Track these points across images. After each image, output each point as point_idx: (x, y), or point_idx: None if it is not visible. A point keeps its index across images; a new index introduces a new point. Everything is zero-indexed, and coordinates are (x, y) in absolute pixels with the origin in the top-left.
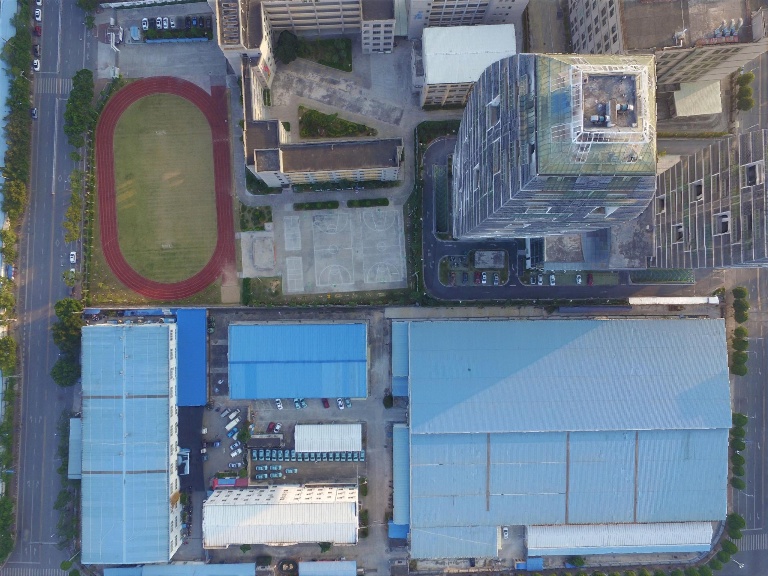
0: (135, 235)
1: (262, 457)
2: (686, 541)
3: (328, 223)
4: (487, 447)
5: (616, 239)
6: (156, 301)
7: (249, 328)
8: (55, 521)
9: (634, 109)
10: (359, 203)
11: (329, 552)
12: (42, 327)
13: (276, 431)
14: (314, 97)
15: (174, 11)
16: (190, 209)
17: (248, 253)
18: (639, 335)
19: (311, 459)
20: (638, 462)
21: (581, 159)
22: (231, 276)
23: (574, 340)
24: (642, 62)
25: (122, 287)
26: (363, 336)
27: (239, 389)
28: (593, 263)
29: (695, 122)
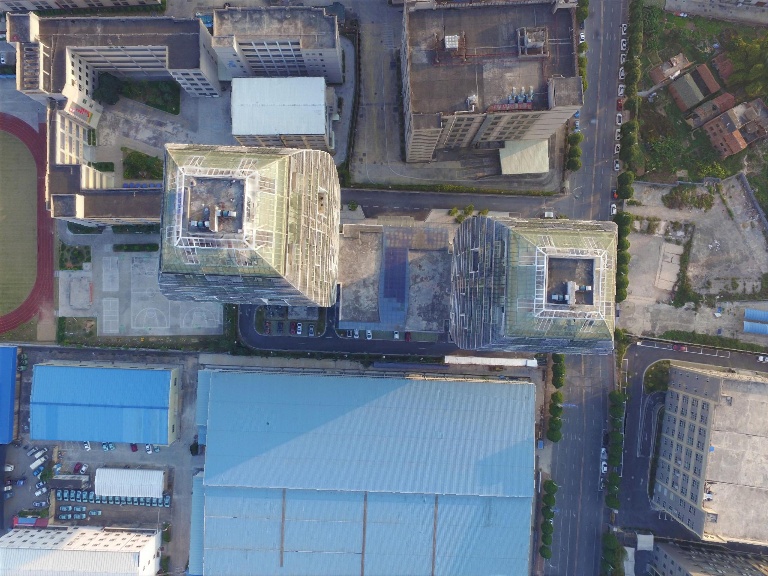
0: None
1: (66, 497)
2: None
3: (147, 265)
4: (282, 502)
5: (415, 301)
6: None
7: (53, 369)
8: None
9: (242, 214)
10: None
11: None
12: None
13: (82, 472)
14: (140, 138)
15: (6, 47)
16: (11, 245)
17: (65, 292)
18: (445, 397)
19: (116, 502)
20: (437, 526)
21: (194, 261)
22: (48, 314)
23: (378, 399)
24: (258, 165)
25: None
26: (167, 383)
27: (40, 430)
28: (389, 324)
29: (526, 179)
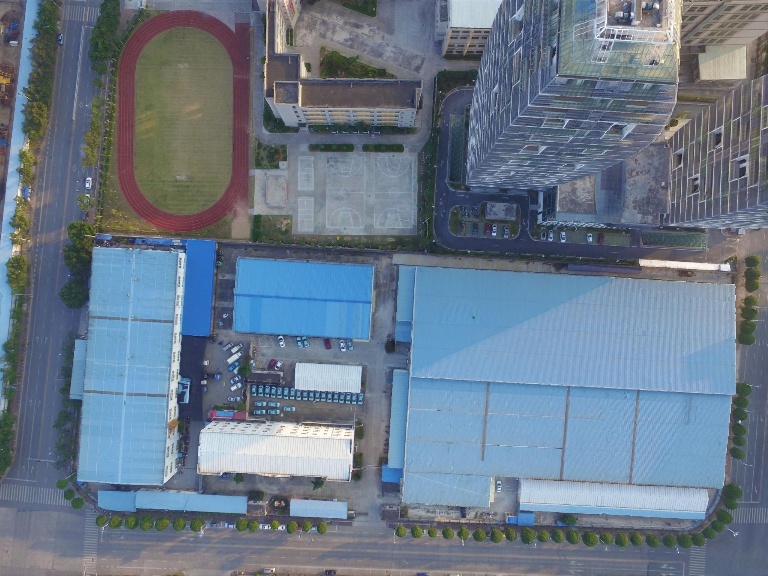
0: (151, 165)
1: (261, 393)
2: (681, 507)
3: (342, 166)
4: (486, 396)
5: (630, 194)
6: (167, 232)
7: (257, 262)
8: (54, 441)
9: (659, 9)
10: (374, 148)
11: (321, 492)
12: (54, 250)
13: (277, 368)
14: (336, 40)
15: None
16: (207, 143)
17: (261, 190)
18: (647, 295)
19: (310, 398)
20: (637, 423)
21: (602, 59)
22: (243, 212)
23: (581, 295)
24: None
25: (135, 216)
26: (369, 278)
27: (243, 322)
28: (605, 216)
29: (718, 88)
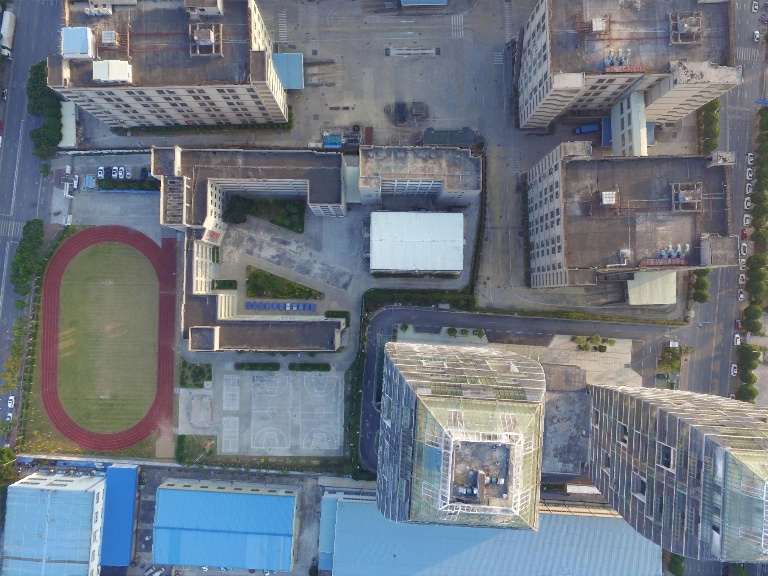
0: (75, 383)
1: None
2: None
3: (268, 385)
4: None
5: (551, 441)
6: (90, 451)
7: (177, 493)
8: None
9: (506, 478)
10: (300, 367)
11: None
12: None
13: None
14: (264, 256)
15: (131, 161)
16: (131, 360)
17: (185, 409)
18: (572, 532)
19: None
20: None
21: (451, 518)
22: (167, 431)
23: (504, 532)
24: (520, 425)
25: (58, 434)
26: (291, 509)
27: (162, 554)
28: None
29: (650, 307)
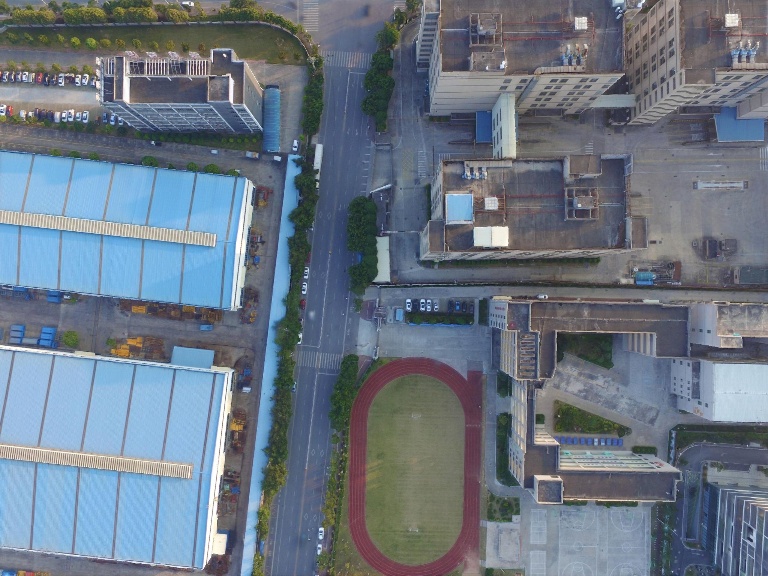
0: (382, 515)
1: None
2: None
3: (575, 519)
4: None
5: None
6: None
7: None
8: None
9: None
10: (608, 502)
11: None
12: None
13: None
14: (571, 391)
15: (437, 293)
16: (438, 493)
17: (493, 543)
18: None
19: None
20: None
21: None
22: (473, 563)
23: None
24: None
25: (366, 566)
26: None
27: None
28: None
29: None
